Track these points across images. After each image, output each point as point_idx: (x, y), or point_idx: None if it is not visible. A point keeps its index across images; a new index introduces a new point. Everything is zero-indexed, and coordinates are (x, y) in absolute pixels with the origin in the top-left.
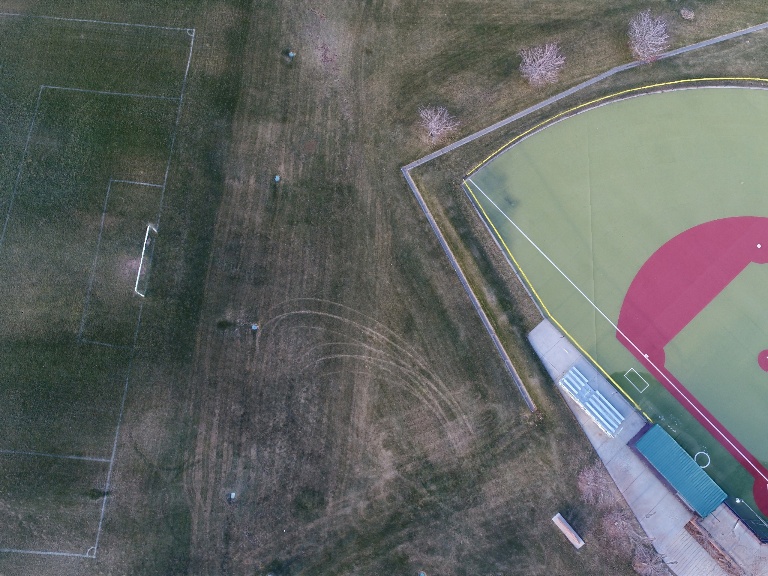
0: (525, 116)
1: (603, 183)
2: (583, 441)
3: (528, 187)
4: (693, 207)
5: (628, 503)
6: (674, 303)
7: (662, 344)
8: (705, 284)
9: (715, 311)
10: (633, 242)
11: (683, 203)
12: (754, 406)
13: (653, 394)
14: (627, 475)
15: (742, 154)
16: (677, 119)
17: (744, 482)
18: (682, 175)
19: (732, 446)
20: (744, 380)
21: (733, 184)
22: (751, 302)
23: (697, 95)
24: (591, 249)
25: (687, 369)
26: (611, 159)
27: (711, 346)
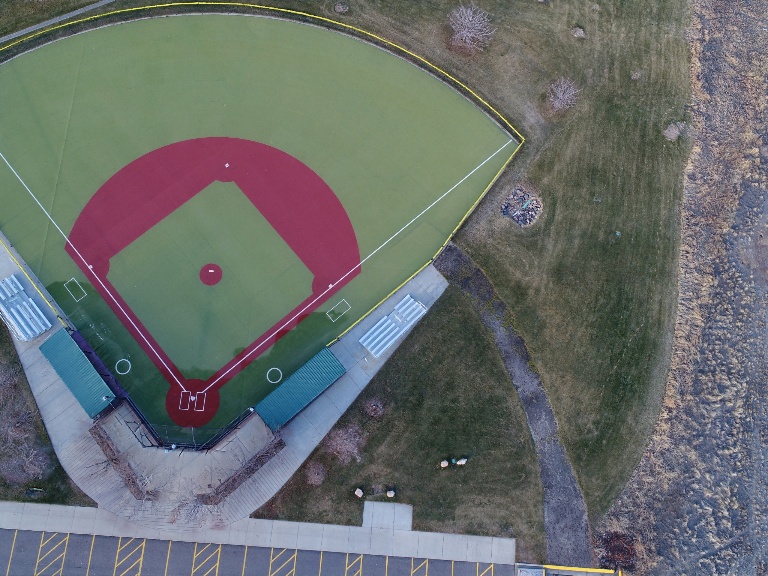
0: (24, 34)
1: (86, 101)
2: (7, 346)
3: (10, 102)
4: (170, 126)
5: (38, 406)
6: (130, 217)
7: (109, 256)
8: (165, 200)
9: (168, 226)
10: (103, 158)
11: (162, 122)
12: (186, 317)
13: (89, 303)
14: (44, 380)
15: (231, 78)
16: (175, 43)
17: (159, 389)
18: (167, 96)
19: (155, 354)
20: (182, 292)
21: (215, 106)
22: (206, 218)
23: (200, 20)
24: (59, 163)
25: (128, 280)
26: (100, 78)
27: (157, 259)
